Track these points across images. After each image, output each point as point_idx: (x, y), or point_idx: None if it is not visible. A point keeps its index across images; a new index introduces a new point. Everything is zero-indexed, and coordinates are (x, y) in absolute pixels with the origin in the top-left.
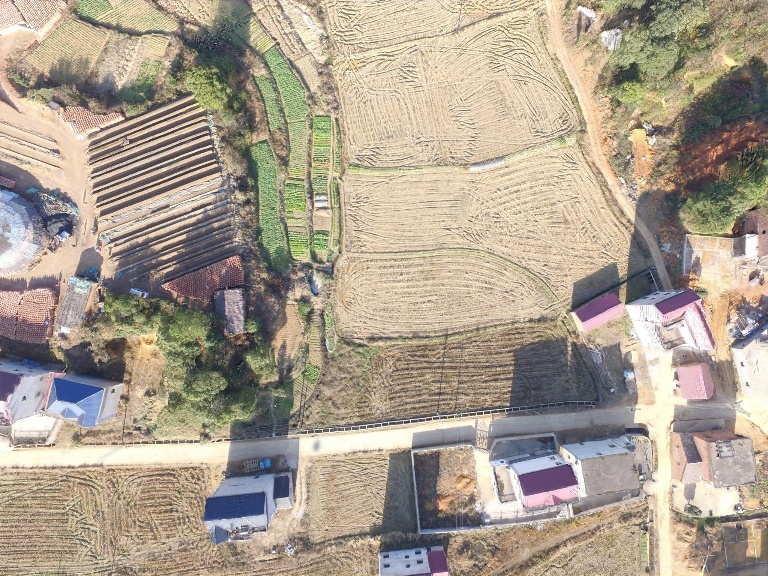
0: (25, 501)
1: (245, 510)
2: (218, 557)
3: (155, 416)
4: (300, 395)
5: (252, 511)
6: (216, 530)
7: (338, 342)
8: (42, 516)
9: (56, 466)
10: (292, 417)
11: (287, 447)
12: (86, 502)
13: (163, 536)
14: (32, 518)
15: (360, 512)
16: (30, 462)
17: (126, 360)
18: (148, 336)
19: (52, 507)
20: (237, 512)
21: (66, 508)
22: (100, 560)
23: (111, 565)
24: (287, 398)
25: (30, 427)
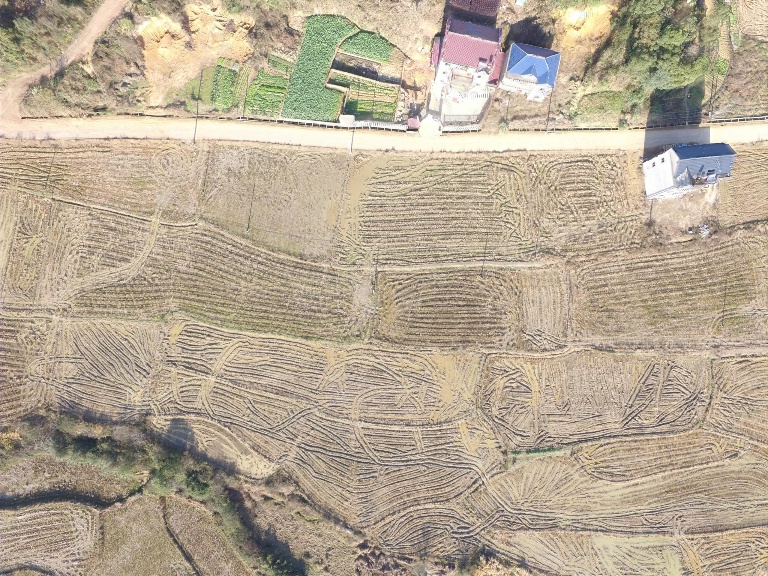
0: (451, 185)
1: (717, 151)
2: (637, 237)
3: (576, 104)
4: (711, 86)
5: (724, 152)
6: (689, 171)
7: (743, 38)
8: (468, 199)
9: (482, 151)
10: (704, 106)
11: (699, 135)
12: (510, 186)
13: (583, 219)
14: (459, 201)
15: (766, 199)
16: (457, 147)
17: (551, 47)
18: (575, 22)
19: (477, 191)
20: (711, 152)
21: (491, 192)
22: (524, 241)
23: (535, 246)
24: (699, 88)
25: (459, 111)
